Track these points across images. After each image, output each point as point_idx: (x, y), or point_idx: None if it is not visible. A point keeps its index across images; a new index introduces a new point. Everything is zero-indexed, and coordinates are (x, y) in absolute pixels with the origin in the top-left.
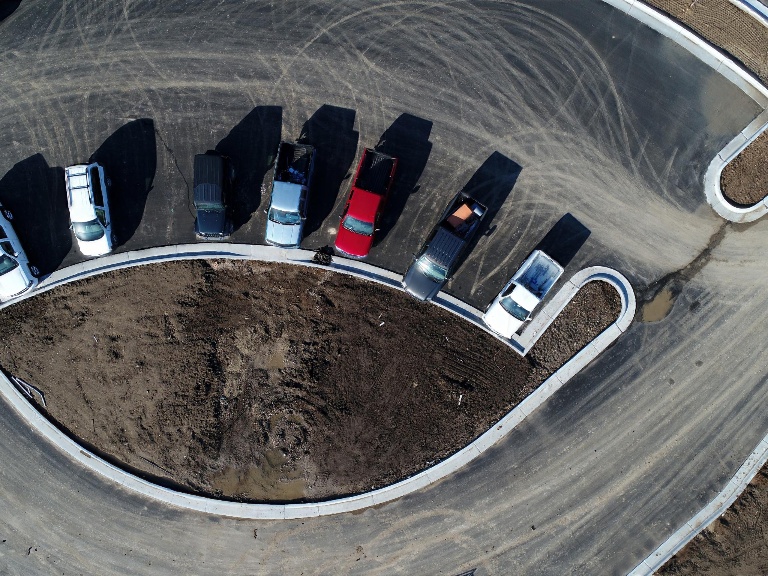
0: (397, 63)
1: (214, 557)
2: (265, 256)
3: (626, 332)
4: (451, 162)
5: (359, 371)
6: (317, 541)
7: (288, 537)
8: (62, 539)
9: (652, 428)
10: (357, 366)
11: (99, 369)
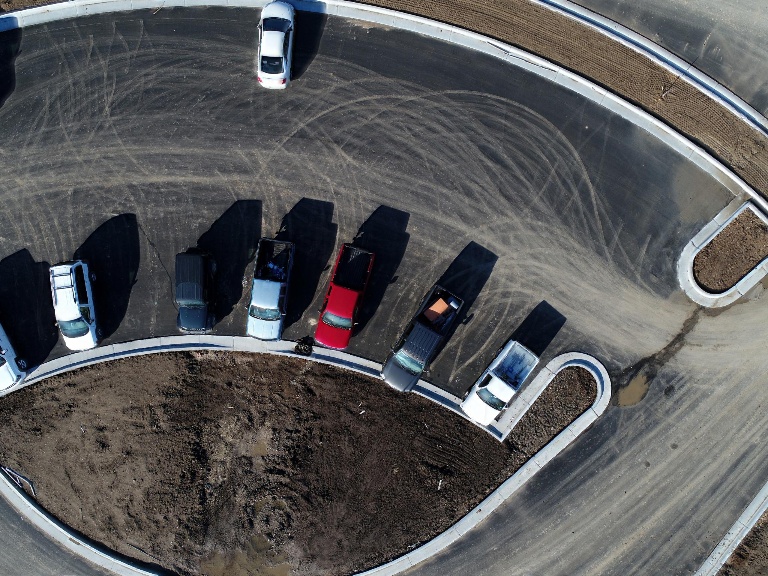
0: (374, 156)
1: None
2: (247, 347)
3: (602, 416)
4: (428, 252)
5: (340, 458)
6: None
7: None
8: None
9: (628, 510)
10: (338, 453)
11: (86, 459)
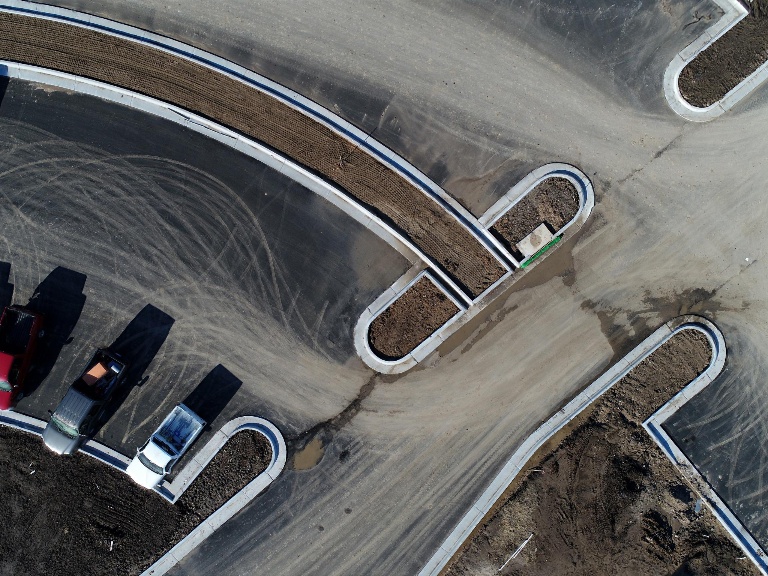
0: (53, 218)
1: None
2: None
3: (277, 480)
4: (105, 314)
5: (11, 517)
6: None
7: None
8: None
9: (302, 574)
10: (9, 513)
11: None
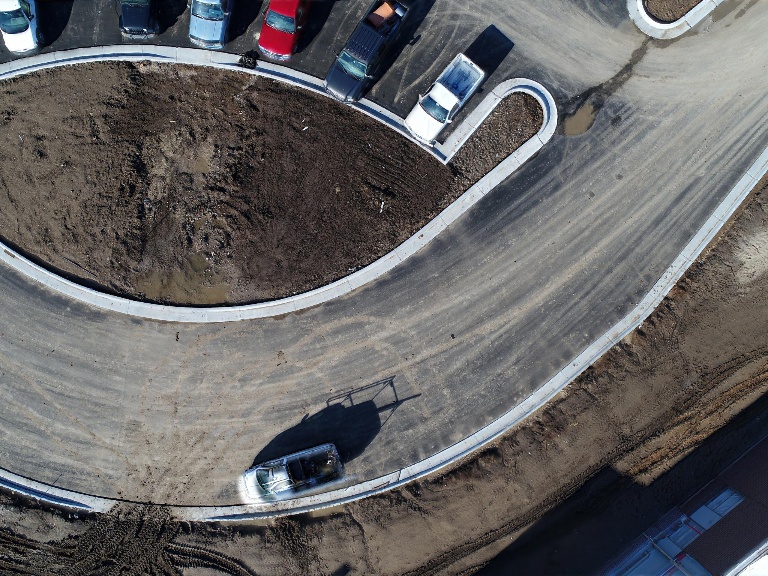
0: None
1: (136, 359)
2: (190, 59)
3: (548, 145)
4: None
5: (282, 175)
6: (238, 345)
7: (210, 341)
8: None
9: (572, 240)
10: (280, 170)
11: (24, 168)
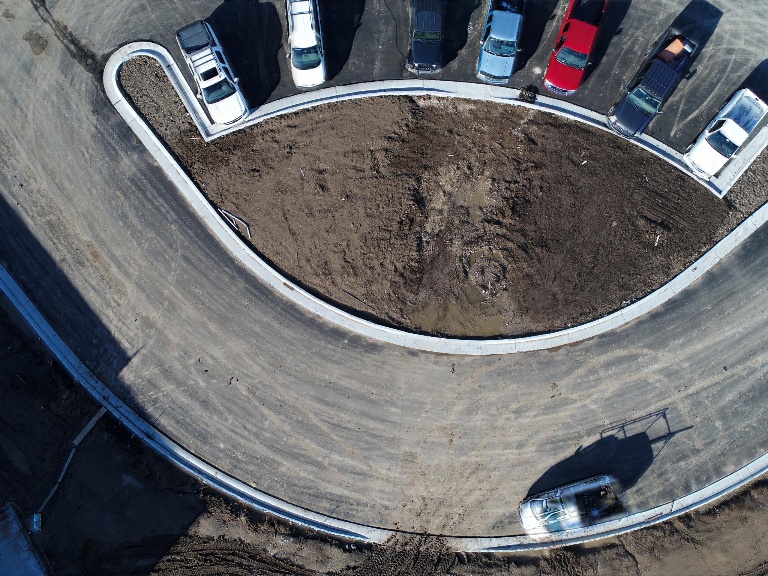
0: None
1: (412, 391)
2: (471, 93)
3: None
4: (654, 6)
5: (560, 209)
6: (513, 377)
7: (485, 373)
8: (263, 370)
9: None
10: (558, 204)
11: (305, 202)
